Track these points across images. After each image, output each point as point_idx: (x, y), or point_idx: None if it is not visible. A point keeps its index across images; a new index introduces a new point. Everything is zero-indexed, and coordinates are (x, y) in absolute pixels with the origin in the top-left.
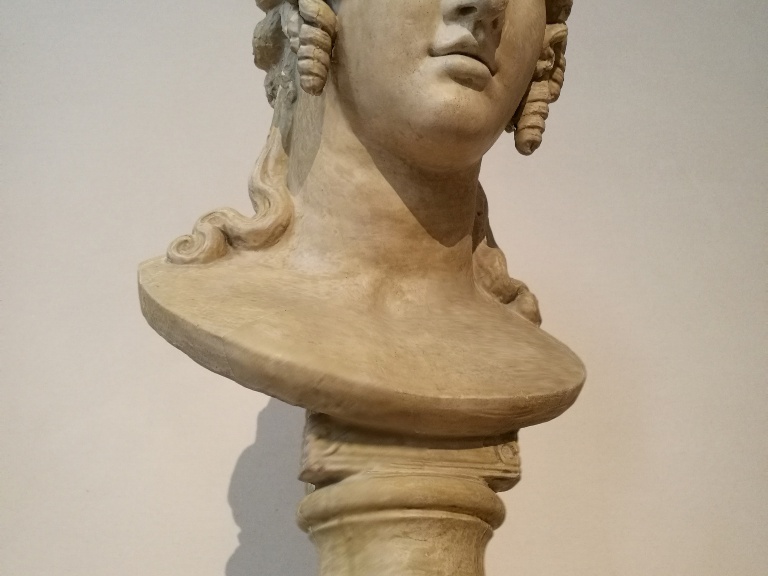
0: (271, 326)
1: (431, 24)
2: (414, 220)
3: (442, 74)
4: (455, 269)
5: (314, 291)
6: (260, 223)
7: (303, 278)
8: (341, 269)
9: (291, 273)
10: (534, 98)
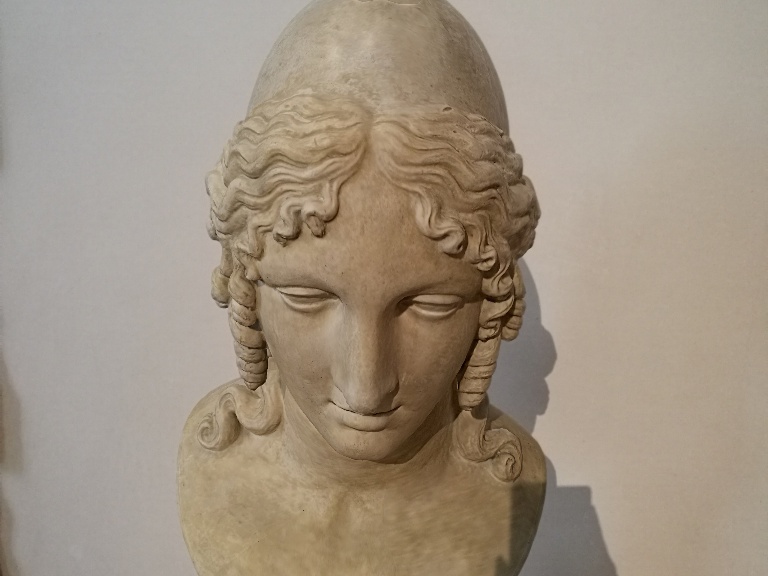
0: (239, 573)
1: (326, 385)
2: (364, 460)
3: (341, 424)
4: (417, 469)
5: (291, 502)
6: (256, 424)
7: (287, 481)
8: (313, 481)
9: (280, 471)
10: (475, 364)
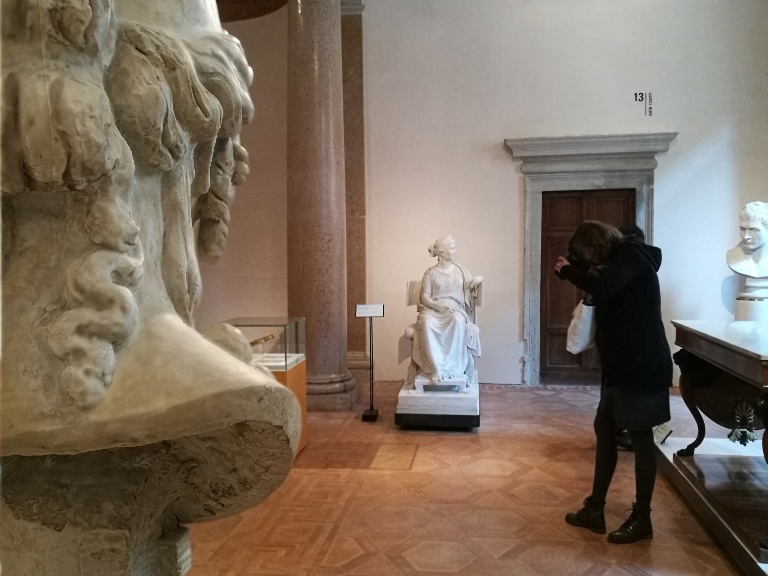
0: None
1: None
2: None
3: None
4: None
5: None
6: None
7: None
8: None
9: None
10: None
